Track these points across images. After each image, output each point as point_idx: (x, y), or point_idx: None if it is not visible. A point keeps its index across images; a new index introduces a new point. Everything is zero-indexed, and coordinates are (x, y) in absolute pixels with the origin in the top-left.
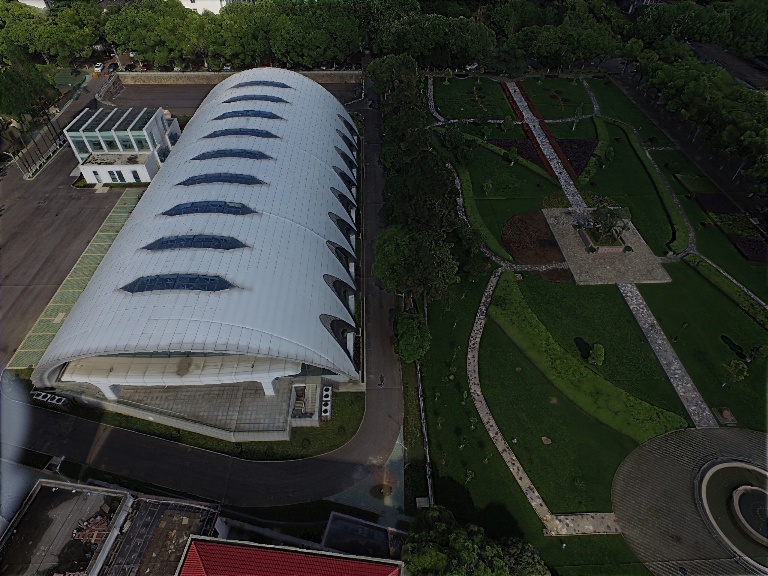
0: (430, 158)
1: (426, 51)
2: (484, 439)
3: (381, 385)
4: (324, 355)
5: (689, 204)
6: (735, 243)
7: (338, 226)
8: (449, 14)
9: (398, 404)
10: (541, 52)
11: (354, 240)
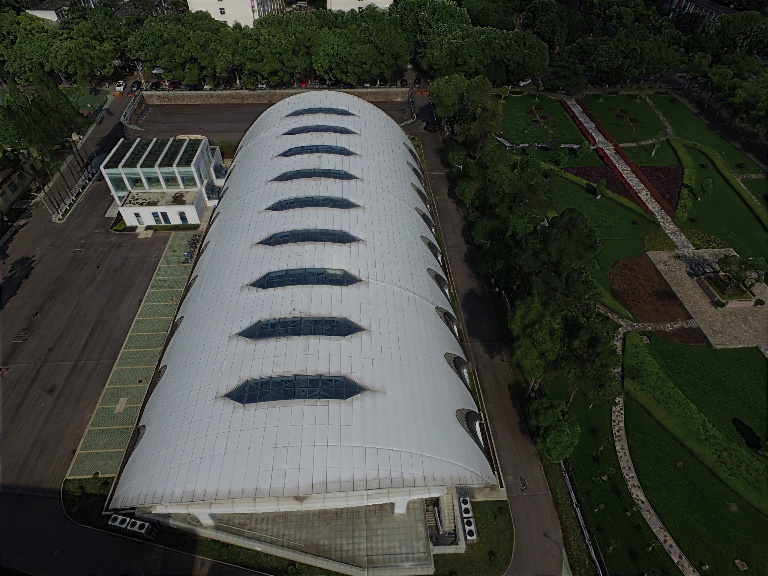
0: (580, 219)
1: (481, 67)
2: (667, 565)
3: (524, 490)
4: (473, 468)
5: None
6: None
7: (438, 284)
8: (491, 24)
9: (551, 517)
10: (602, 67)
11: (449, 296)
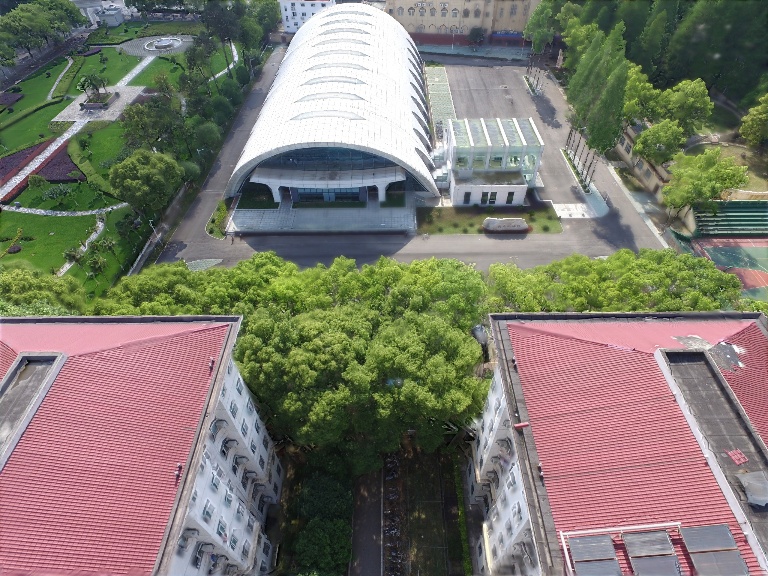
0: None
1: None
2: None
3: None
4: None
5: None
6: None
7: None
8: None
9: None
10: None
11: None
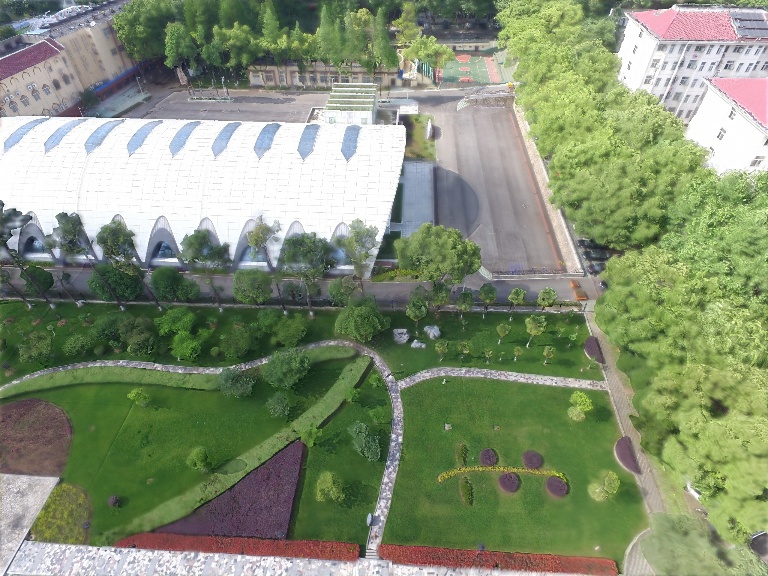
0: None
1: (614, 338)
2: None
3: None
4: None
5: None
6: None
7: None
8: None
9: None
10: None
11: None
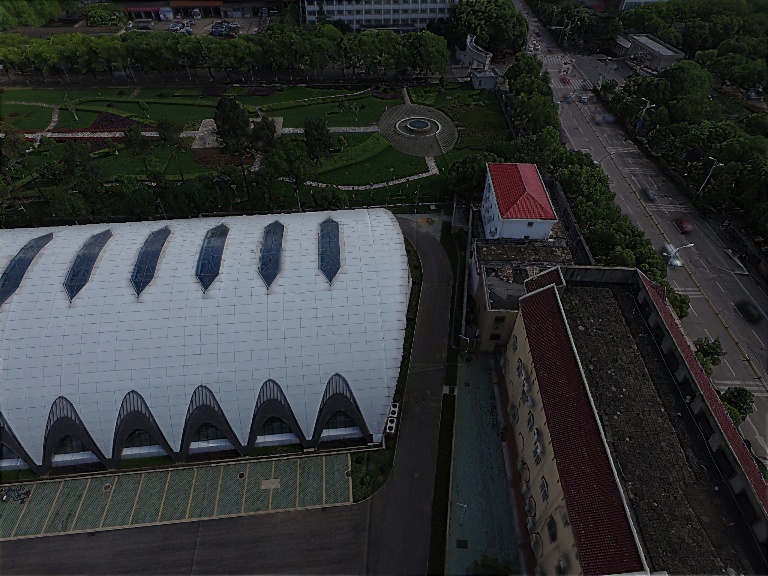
0: None
1: None
2: (394, 187)
3: None
4: None
5: (210, 99)
6: (255, 94)
7: None
8: None
9: None
10: None
11: None
